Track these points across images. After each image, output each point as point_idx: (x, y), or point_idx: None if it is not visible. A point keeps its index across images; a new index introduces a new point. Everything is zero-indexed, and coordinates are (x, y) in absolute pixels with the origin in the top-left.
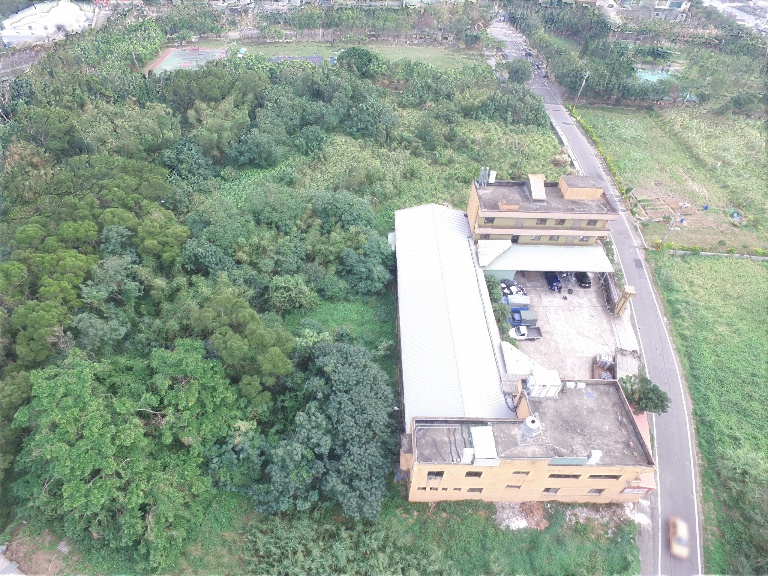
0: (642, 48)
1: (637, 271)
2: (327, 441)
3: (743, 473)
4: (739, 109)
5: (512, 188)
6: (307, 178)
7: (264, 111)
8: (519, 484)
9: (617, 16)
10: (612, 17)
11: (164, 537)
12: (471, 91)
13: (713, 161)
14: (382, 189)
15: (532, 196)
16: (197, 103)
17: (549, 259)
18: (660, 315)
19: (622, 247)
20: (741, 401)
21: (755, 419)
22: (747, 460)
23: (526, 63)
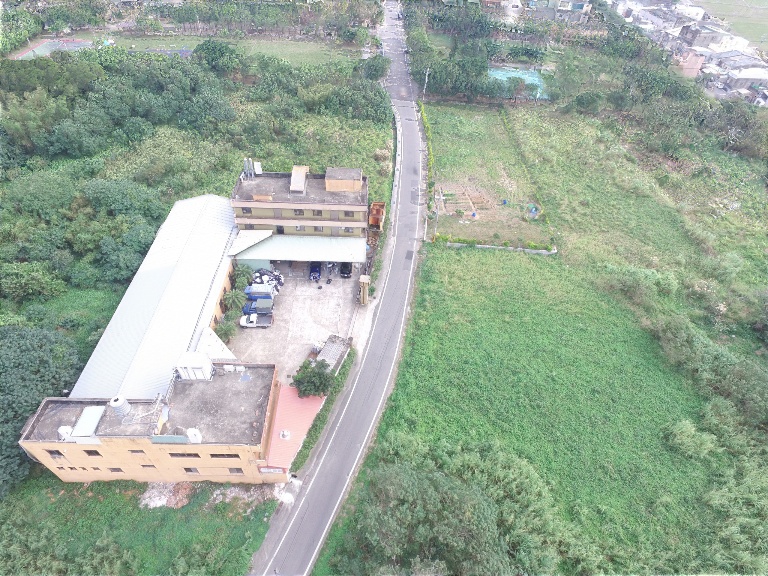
0: (531, 48)
1: (404, 262)
2: None
3: (394, 454)
4: (584, 108)
5: (280, 179)
6: (113, 169)
7: (84, 102)
8: (150, 463)
9: (521, 16)
10: (515, 17)
11: None
12: (318, 86)
13: (537, 158)
14: (180, 180)
15: (290, 187)
16: (2, 92)
17: (306, 249)
18: (405, 305)
19: (401, 239)
20: (438, 387)
21: (445, 404)
22: (403, 442)
23: (386, 60)
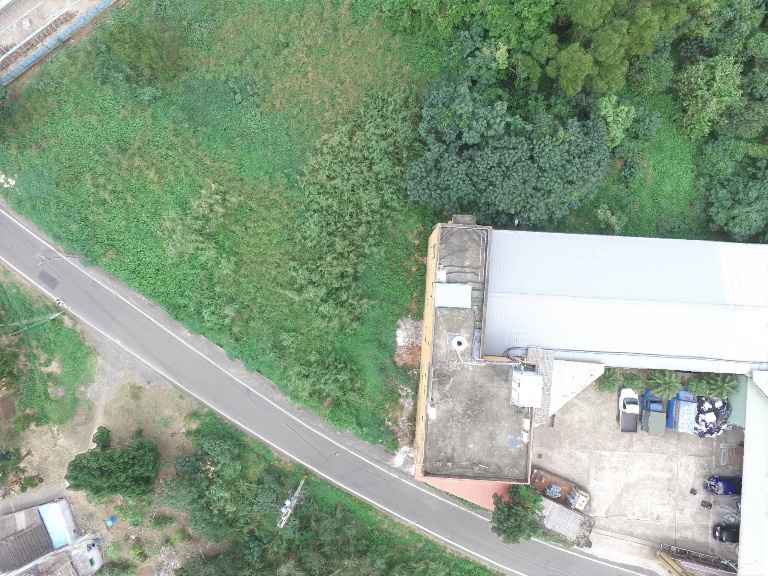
0: None
1: None
2: (473, 138)
3: None
4: None
5: None
6: None
7: None
8: None
9: None
10: None
11: (402, 6)
12: None
13: None
14: None
15: None
16: None
17: None
18: None
19: None
20: None
21: None
22: None
23: None
